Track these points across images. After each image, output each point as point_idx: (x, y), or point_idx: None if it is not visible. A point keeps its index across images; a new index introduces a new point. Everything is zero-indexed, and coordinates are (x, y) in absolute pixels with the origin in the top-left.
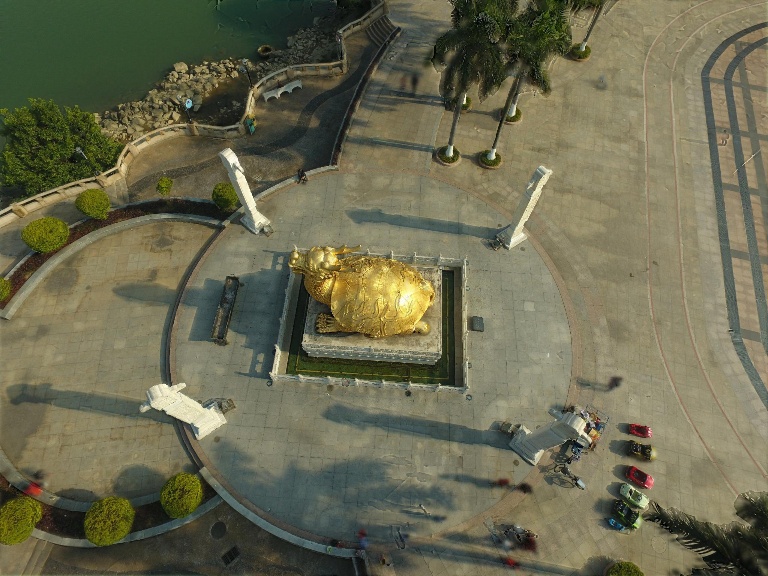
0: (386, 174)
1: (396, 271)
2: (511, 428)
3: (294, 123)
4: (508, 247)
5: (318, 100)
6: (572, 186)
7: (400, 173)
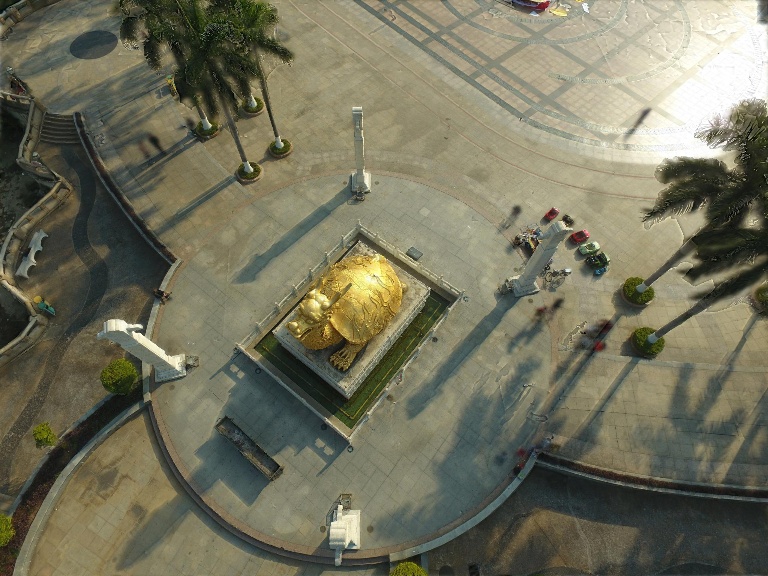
0: (224, 227)
1: (353, 266)
2: (507, 286)
3: (83, 268)
4: (368, 190)
5: (79, 231)
6: (351, 117)
7: (233, 216)
